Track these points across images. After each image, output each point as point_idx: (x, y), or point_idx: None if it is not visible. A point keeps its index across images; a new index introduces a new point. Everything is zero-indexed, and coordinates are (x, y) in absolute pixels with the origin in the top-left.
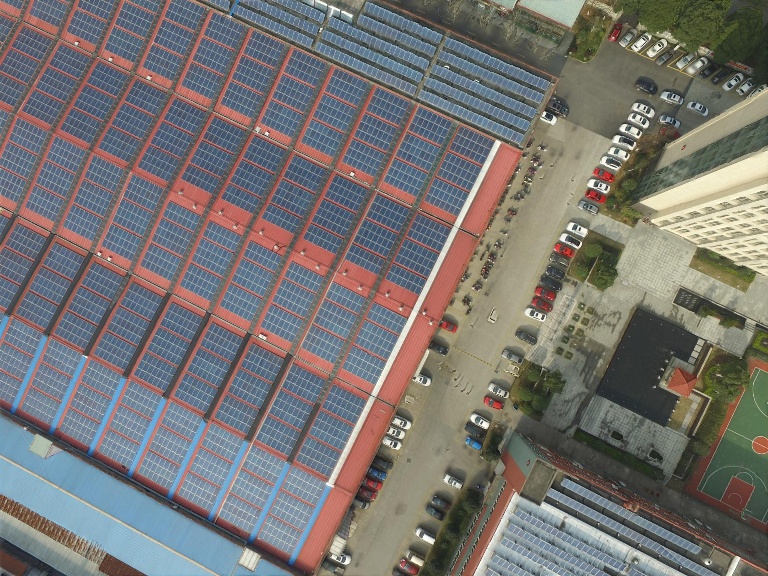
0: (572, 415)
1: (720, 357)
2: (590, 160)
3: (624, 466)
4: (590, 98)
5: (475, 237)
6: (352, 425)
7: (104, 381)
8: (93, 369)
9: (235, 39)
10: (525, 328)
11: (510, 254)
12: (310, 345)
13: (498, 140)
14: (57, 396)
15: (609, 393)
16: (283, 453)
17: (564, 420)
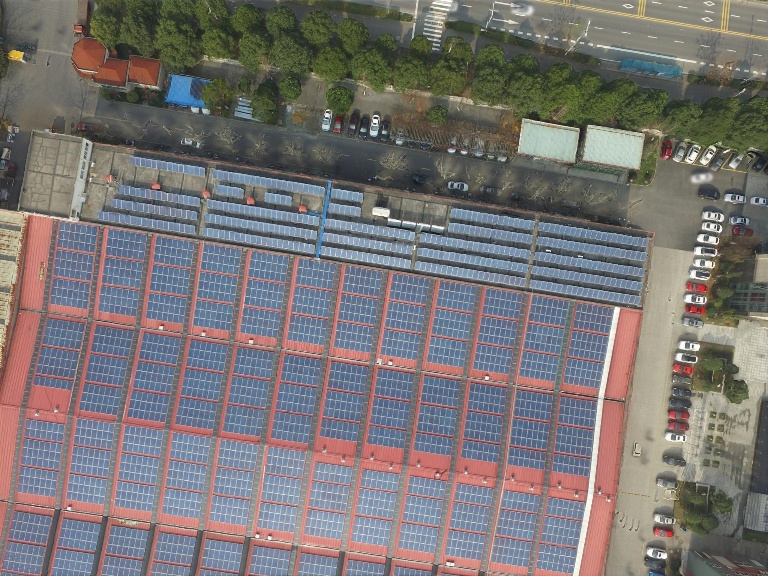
0: (735, 518)
1: None
2: (679, 276)
3: None
4: (662, 218)
5: (621, 402)
6: None
7: None
8: None
9: (330, 279)
10: (669, 452)
11: (634, 387)
12: (499, 557)
13: (617, 307)
14: None
15: (762, 488)
16: None
17: (729, 525)
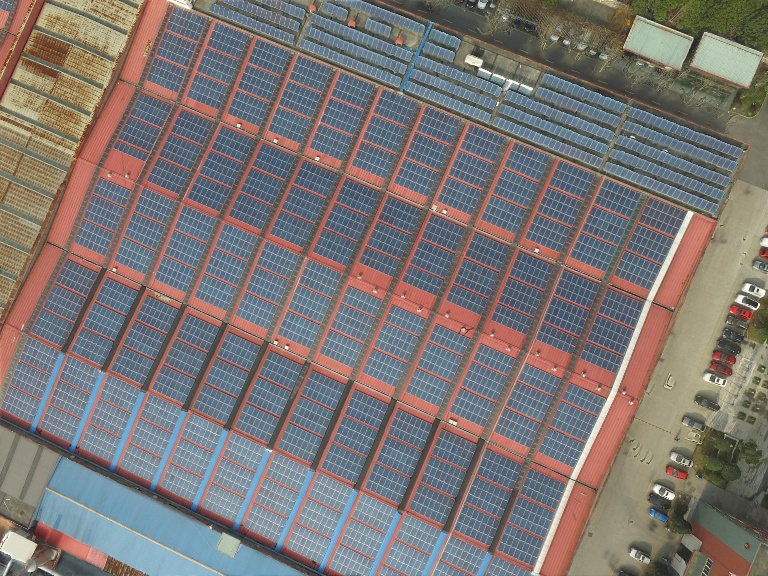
0: (758, 481)
1: None
2: (761, 218)
3: None
4: (757, 154)
5: (669, 311)
6: (553, 510)
7: (290, 475)
8: (278, 463)
9: (407, 116)
10: (704, 393)
11: (683, 318)
12: (503, 429)
13: (691, 211)
14: (240, 492)
15: None
16: (484, 543)
17: (750, 487)
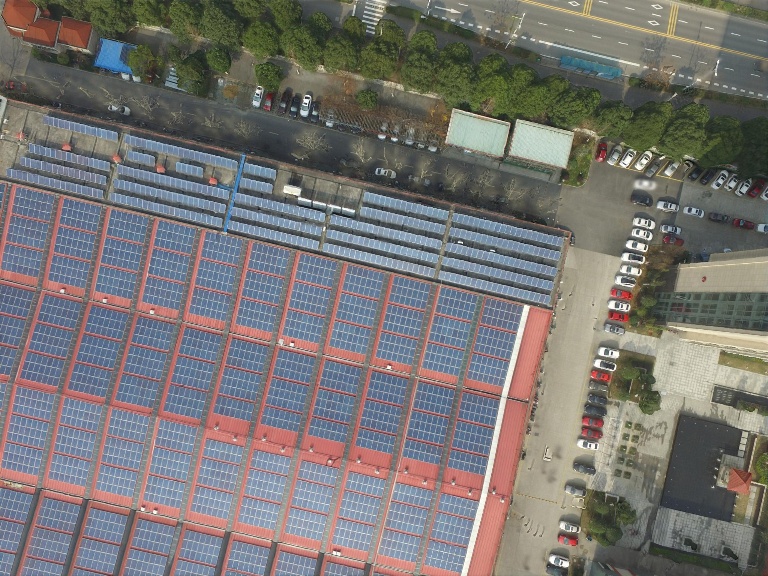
0: (643, 531)
1: (765, 445)
2: (605, 281)
3: (701, 568)
4: (592, 221)
5: (524, 402)
6: None
7: None
8: None
9: (236, 255)
10: (581, 459)
11: (550, 390)
12: (387, 550)
13: (527, 305)
14: None
15: (673, 503)
16: None
17: (637, 538)
